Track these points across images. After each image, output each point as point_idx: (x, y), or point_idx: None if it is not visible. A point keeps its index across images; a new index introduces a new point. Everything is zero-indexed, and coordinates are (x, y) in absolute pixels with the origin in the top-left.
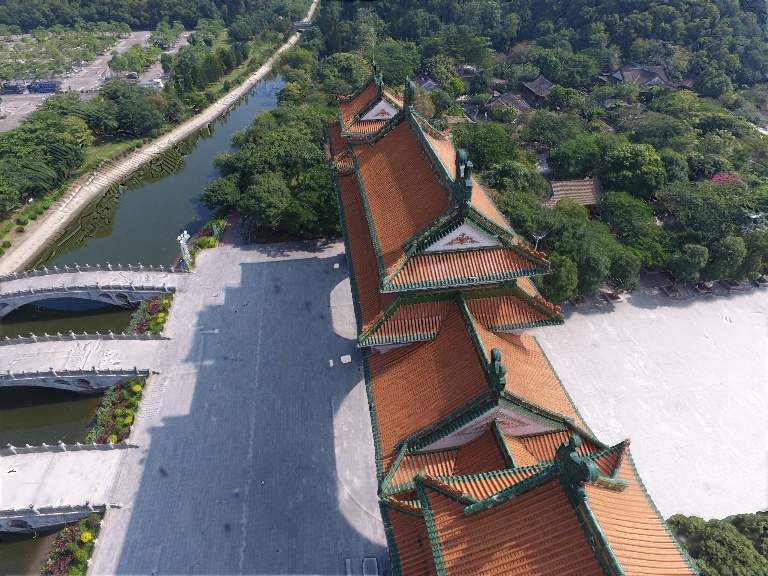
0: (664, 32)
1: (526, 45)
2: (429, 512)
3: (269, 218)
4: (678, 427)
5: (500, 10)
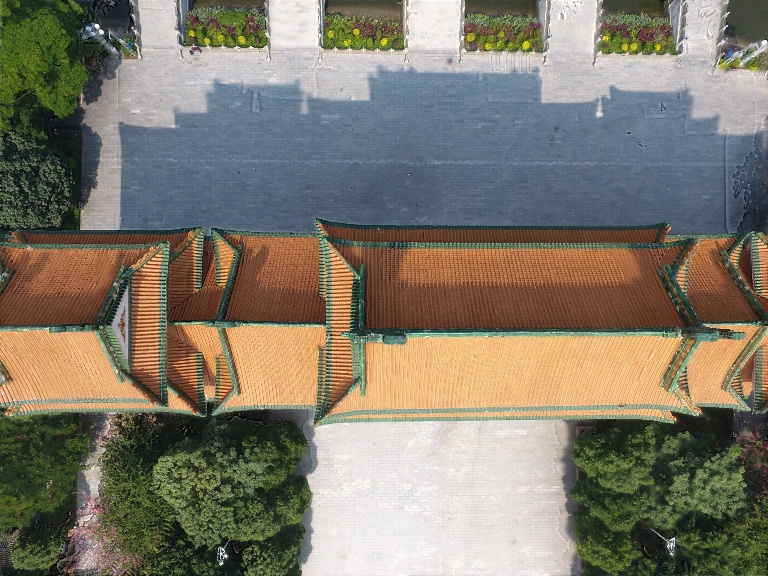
0: None
1: None
2: (143, 247)
3: None
4: (401, 569)
5: None
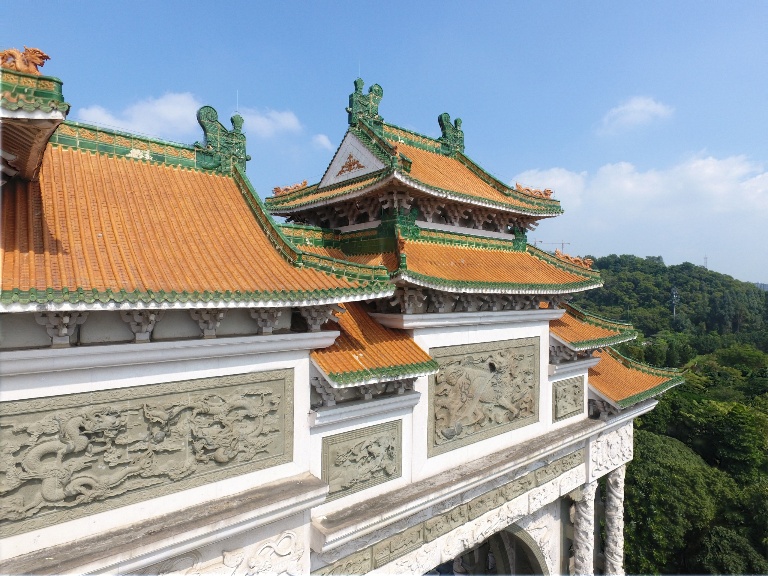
0: None
1: None
2: None
3: None
4: None
5: None
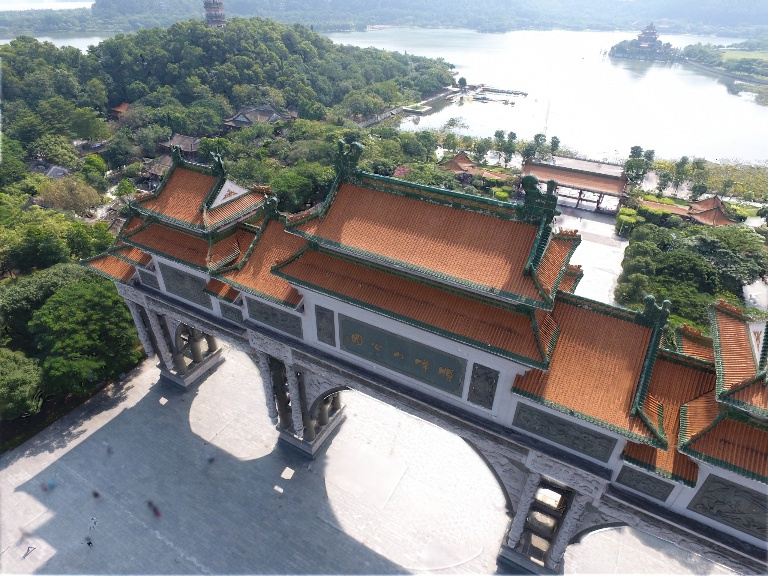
0: (250, 77)
1: (133, 108)
2: (749, 405)
3: (24, 402)
4: None
5: (74, 77)
